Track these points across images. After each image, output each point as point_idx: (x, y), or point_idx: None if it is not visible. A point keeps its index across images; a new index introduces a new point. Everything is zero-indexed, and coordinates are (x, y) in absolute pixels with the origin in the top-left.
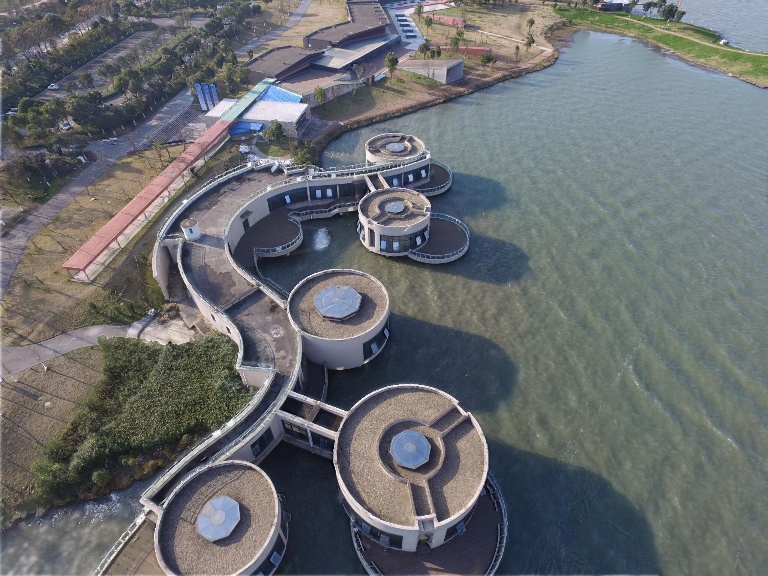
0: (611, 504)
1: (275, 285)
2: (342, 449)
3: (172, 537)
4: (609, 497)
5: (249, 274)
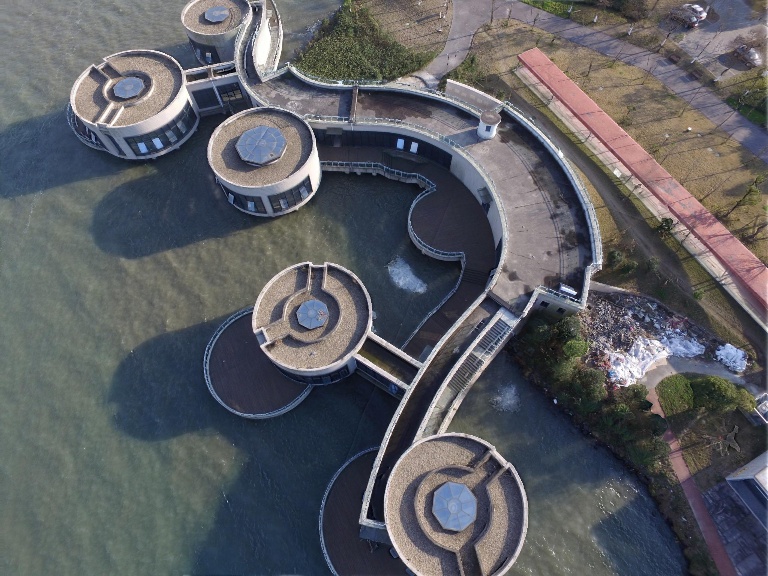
0: (4, 183)
1: (365, 164)
2: (175, 69)
3: (234, 2)
4: (5, 187)
5: (414, 171)
